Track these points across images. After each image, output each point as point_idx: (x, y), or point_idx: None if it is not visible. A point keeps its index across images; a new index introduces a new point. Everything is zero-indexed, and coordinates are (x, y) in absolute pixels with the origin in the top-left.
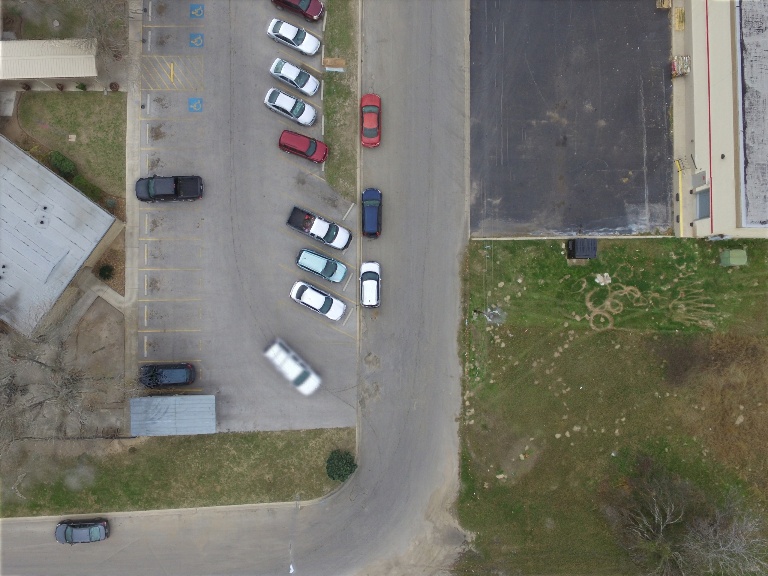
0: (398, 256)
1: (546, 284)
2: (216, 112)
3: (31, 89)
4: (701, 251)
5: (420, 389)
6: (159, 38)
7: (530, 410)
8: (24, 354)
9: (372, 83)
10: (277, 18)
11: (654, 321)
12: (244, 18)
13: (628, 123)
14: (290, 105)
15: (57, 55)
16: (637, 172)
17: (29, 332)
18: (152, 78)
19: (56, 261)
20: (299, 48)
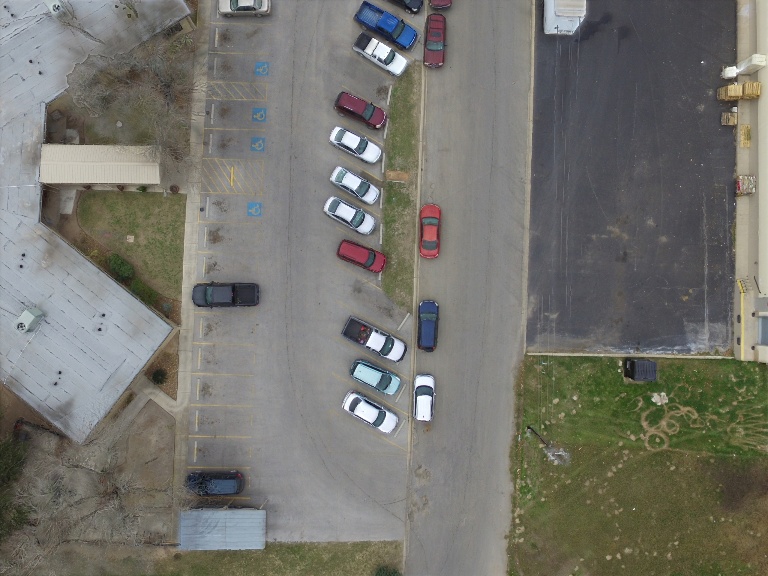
0: (452, 368)
1: (601, 402)
2: (274, 217)
3: (91, 188)
4: (762, 375)
5: (470, 505)
6: (220, 141)
7: (581, 530)
8: (74, 455)
9: (431, 192)
10: (338, 124)
11: (711, 444)
12: (306, 123)
13: (689, 240)
14: (350, 215)
15: (121, 162)
16: (697, 290)
17: (83, 439)
18: (212, 181)
19: (113, 370)
20: (360, 156)
